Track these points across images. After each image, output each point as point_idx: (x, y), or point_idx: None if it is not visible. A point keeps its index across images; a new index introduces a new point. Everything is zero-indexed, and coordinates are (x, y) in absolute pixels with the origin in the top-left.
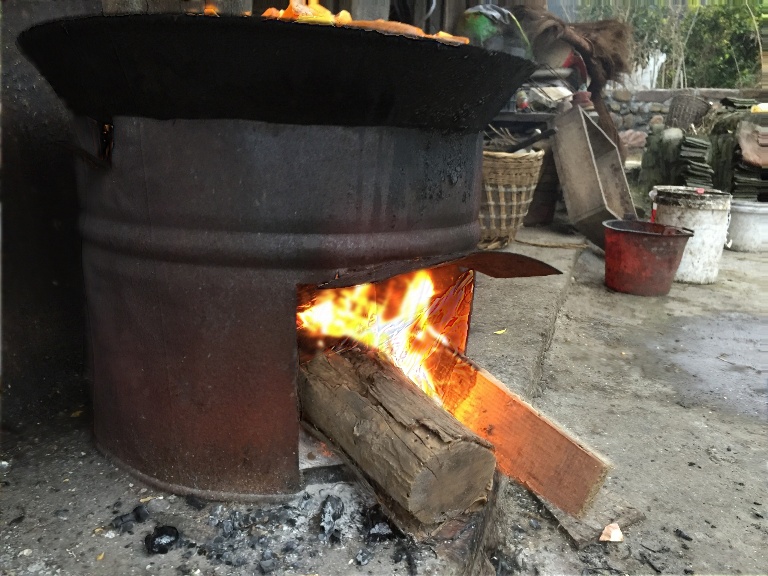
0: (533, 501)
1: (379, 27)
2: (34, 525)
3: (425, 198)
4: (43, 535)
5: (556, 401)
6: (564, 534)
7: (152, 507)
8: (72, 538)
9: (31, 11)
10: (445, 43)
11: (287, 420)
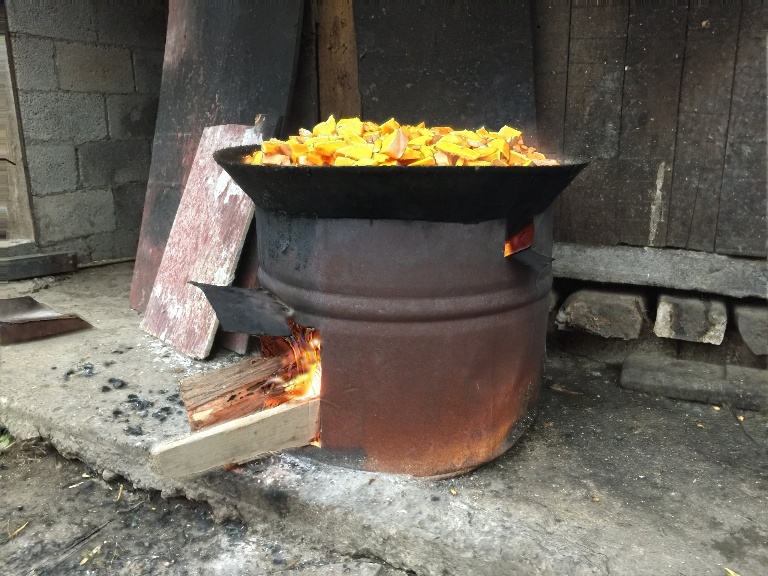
0: None
1: None
2: None
3: (271, 257)
4: None
5: None
6: None
7: None
8: None
9: (468, 113)
10: None
11: None
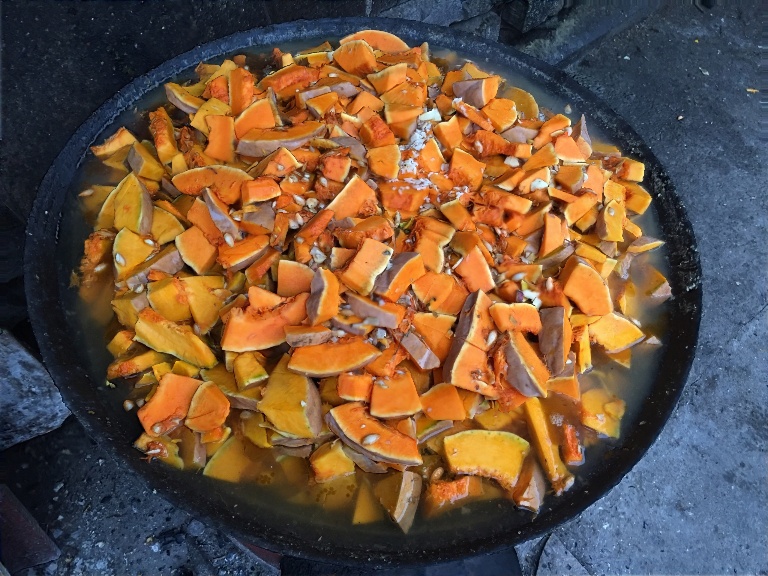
0: None
1: (365, 449)
2: (115, 510)
3: None
4: (116, 528)
5: (678, 435)
6: None
7: (190, 531)
8: (132, 540)
9: None
10: (519, 382)
11: (277, 558)
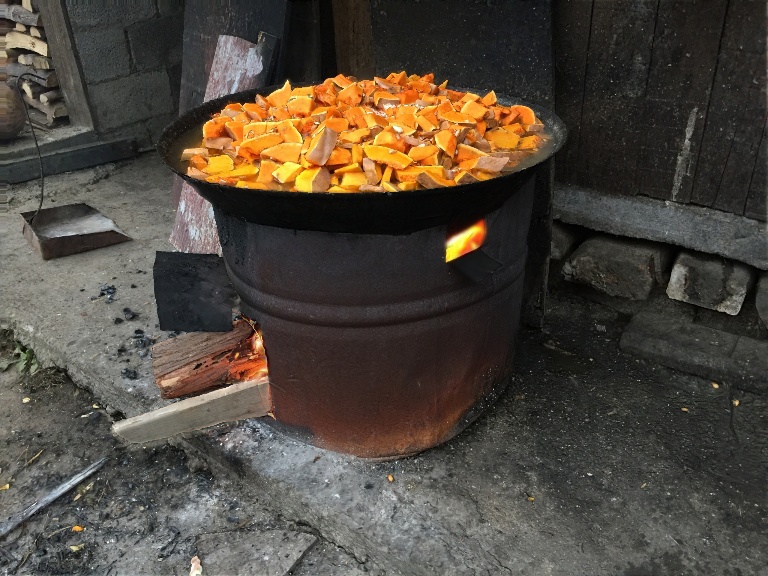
0: None
1: None
2: None
3: None
4: None
5: None
6: None
7: None
8: None
9: (479, 37)
10: None
11: None
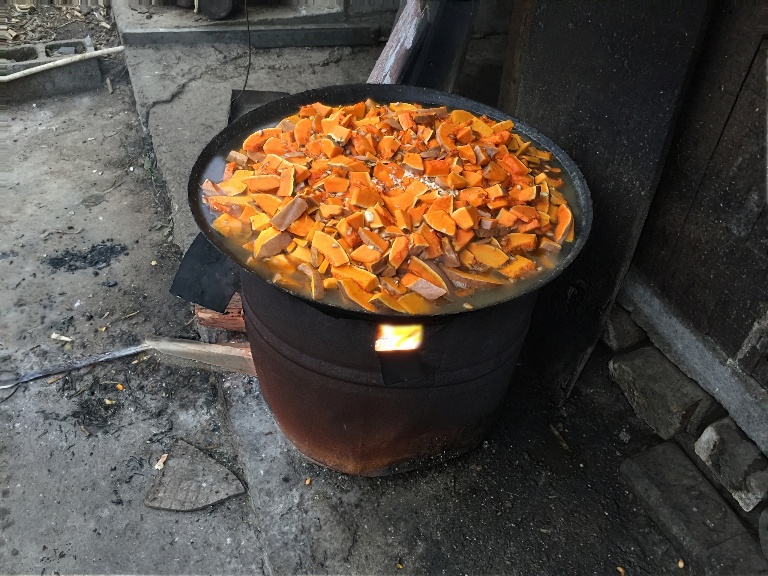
0: (218, 461)
1: None
2: None
3: None
4: None
5: None
6: (189, 443)
7: None
8: None
9: None
10: None
11: None
